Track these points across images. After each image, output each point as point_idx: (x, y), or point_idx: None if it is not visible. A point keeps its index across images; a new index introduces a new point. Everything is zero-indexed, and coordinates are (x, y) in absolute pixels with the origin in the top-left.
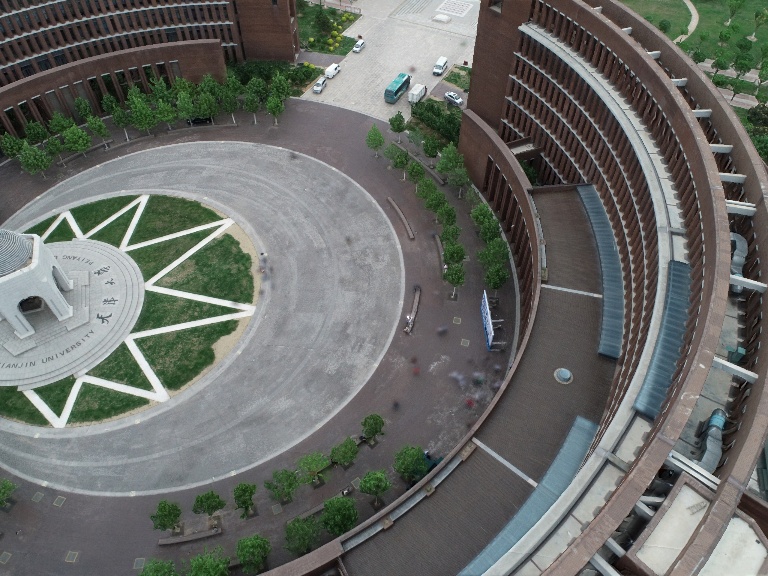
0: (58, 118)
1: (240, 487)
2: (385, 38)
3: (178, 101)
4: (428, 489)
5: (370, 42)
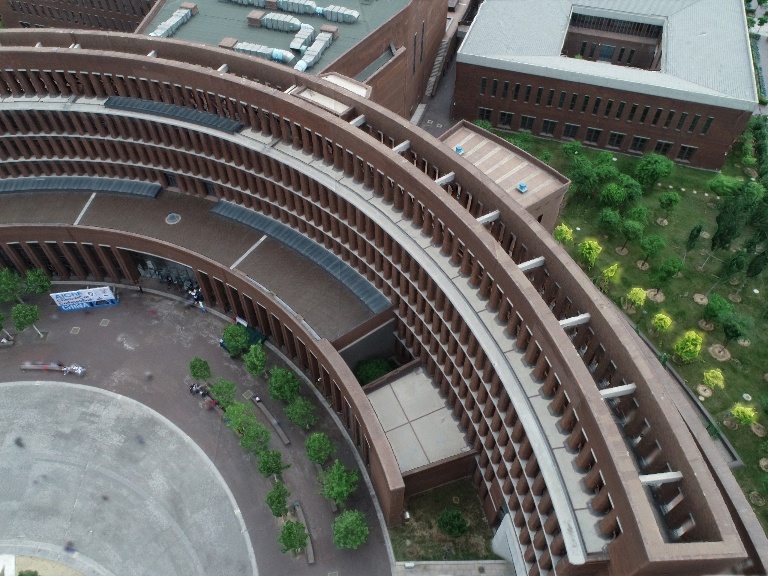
0: None
1: (266, 459)
2: None
3: None
4: None
5: None
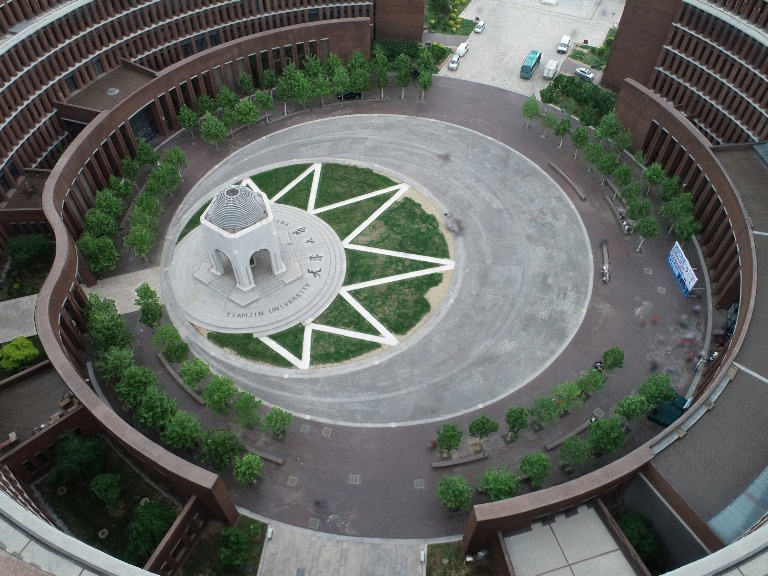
0: (226, 92)
1: (517, 410)
2: (501, 20)
3: (336, 76)
4: (708, 404)
5: (488, 23)
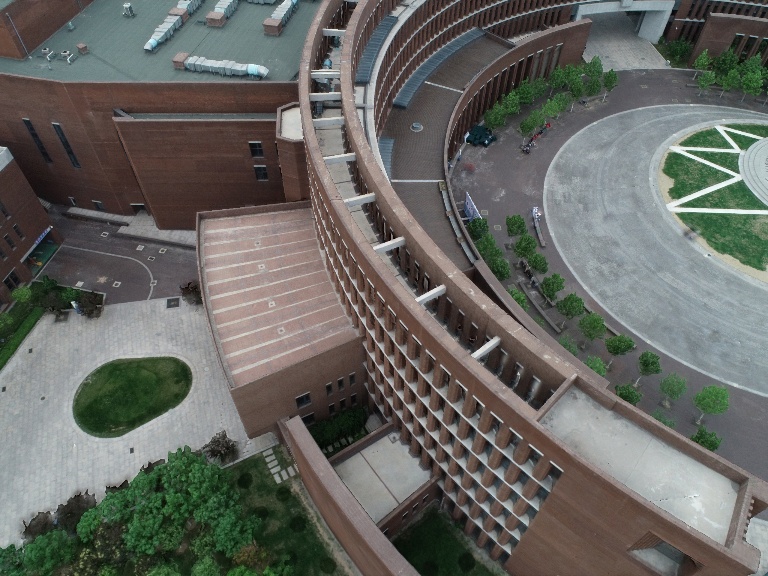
0: None
1: None
2: None
3: None
4: None
5: None
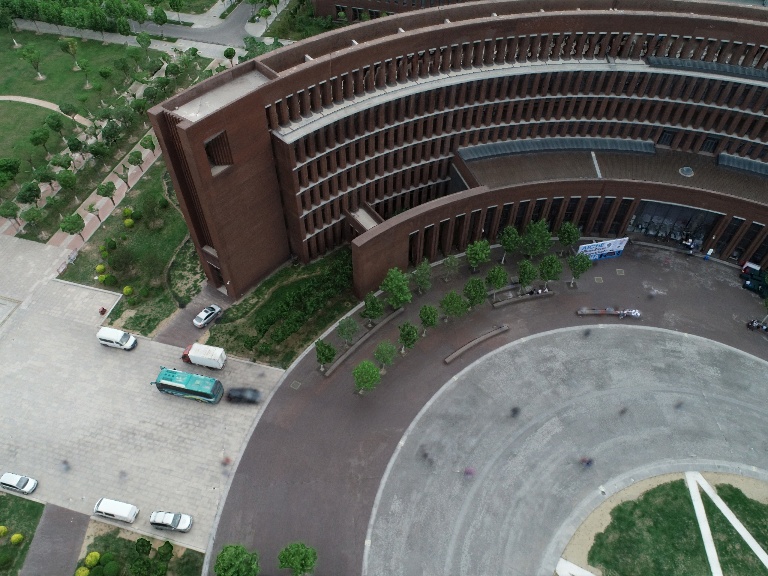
0: None
1: None
2: None
3: None
4: None
5: None
